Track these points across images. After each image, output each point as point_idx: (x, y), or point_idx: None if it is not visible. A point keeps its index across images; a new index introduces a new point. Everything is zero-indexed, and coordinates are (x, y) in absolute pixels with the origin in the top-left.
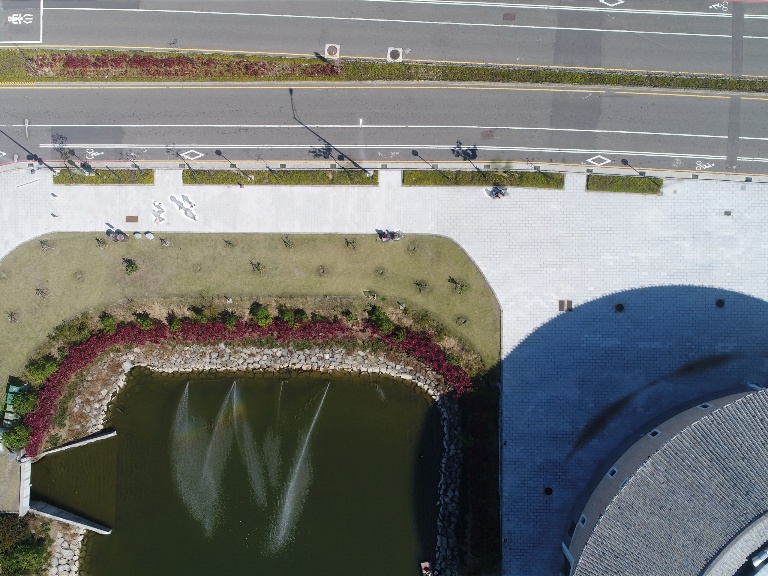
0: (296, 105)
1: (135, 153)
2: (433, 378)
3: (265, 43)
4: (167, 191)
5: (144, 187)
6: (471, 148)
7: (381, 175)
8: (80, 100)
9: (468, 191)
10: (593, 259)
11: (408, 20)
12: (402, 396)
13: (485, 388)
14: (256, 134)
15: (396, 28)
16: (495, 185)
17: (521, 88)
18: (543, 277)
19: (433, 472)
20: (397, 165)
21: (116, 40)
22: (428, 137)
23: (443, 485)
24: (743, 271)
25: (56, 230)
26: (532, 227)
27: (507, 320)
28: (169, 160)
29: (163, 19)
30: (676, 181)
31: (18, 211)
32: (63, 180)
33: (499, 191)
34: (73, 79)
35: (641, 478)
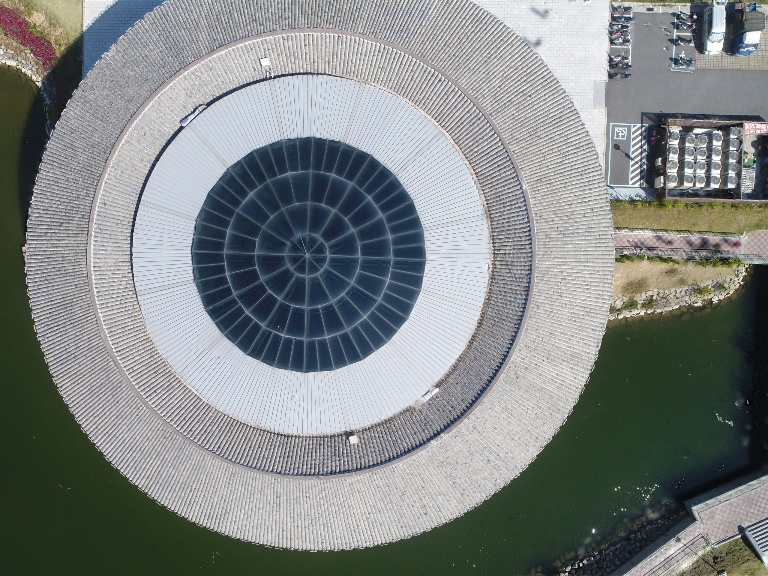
0: None
1: None
2: (33, 62)
3: None
4: None
5: None
6: None
7: None
8: None
9: None
10: None
11: None
12: (10, 85)
13: None
14: None
15: None
16: None
17: None
18: None
19: (37, 159)
20: None
21: None
22: None
23: None
24: None
25: None
26: None
27: None
28: None
29: None
30: None
31: None
32: None
33: None
34: None
35: (105, 62)
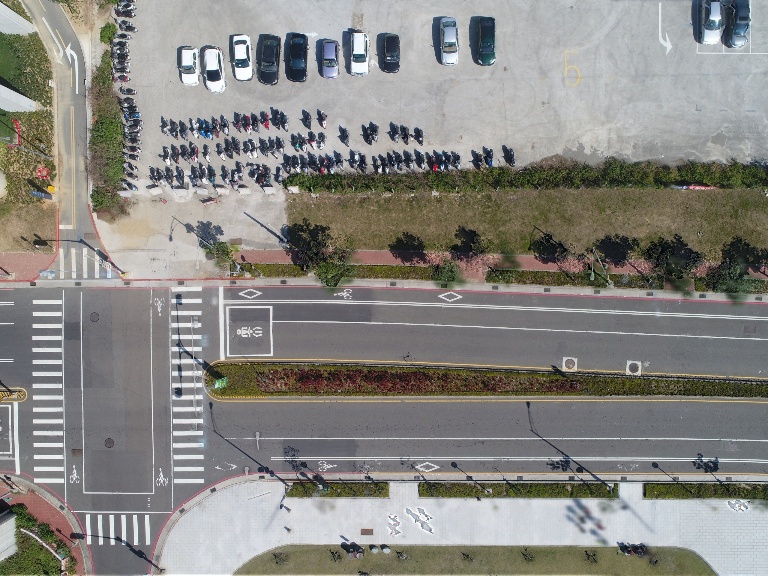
0: (533, 418)
1: (369, 465)
2: None
3: (501, 356)
4: (402, 504)
5: (379, 500)
6: (713, 460)
7: (621, 488)
8: (312, 413)
9: (710, 504)
10: None
11: (647, 333)
12: None
13: None
14: (493, 447)
15: (634, 341)
16: (738, 498)
17: (763, 401)
18: None
19: None
20: (637, 477)
21: (348, 353)
22: (668, 450)
23: None
24: None
25: (289, 543)
26: None
27: None
28: (404, 472)
29: (396, 332)
30: None
31: (250, 524)
32: (297, 494)
33: (742, 504)
34: (306, 394)
35: None
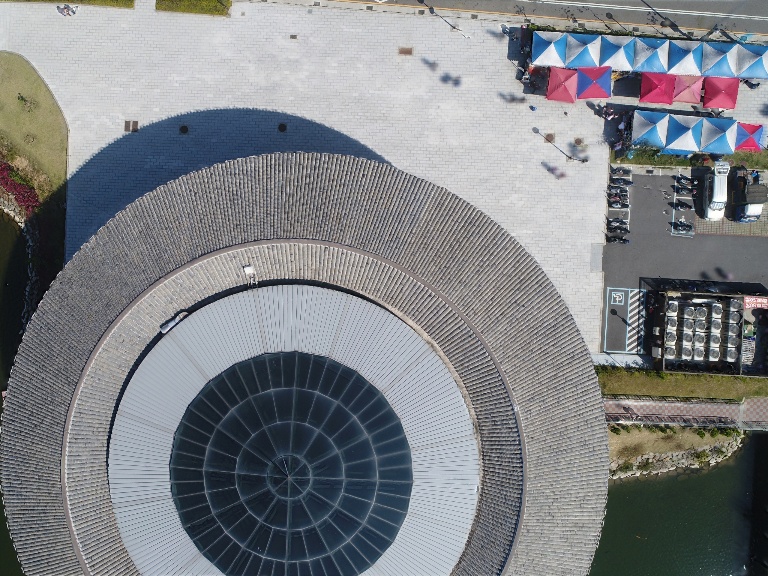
0: None
1: None
2: (16, 203)
3: None
4: None
5: None
6: None
7: None
8: None
9: (40, 8)
10: (160, 80)
11: None
12: None
13: (57, 211)
14: None
15: None
16: (66, 2)
17: None
18: (110, 97)
19: (19, 301)
20: None
21: None
22: None
23: (26, 313)
24: (306, 95)
25: None
26: (101, 46)
27: (73, 139)
28: None
29: None
30: (244, 3)
31: None
32: None
33: (70, 9)
34: None
35: (84, 253)
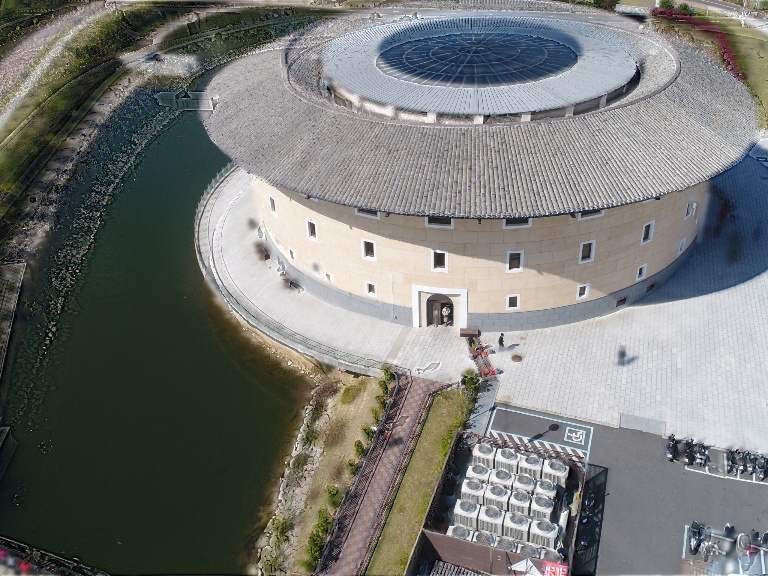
0: None
1: None
2: None
3: None
4: None
5: None
6: None
7: None
8: None
9: None
10: None
11: None
12: None
13: None
14: None
15: None
16: None
17: None
18: None
19: None
20: None
21: None
22: None
23: None
24: None
25: None
26: None
27: None
28: None
29: None
30: None
31: None
32: None
33: None
34: None
35: None
